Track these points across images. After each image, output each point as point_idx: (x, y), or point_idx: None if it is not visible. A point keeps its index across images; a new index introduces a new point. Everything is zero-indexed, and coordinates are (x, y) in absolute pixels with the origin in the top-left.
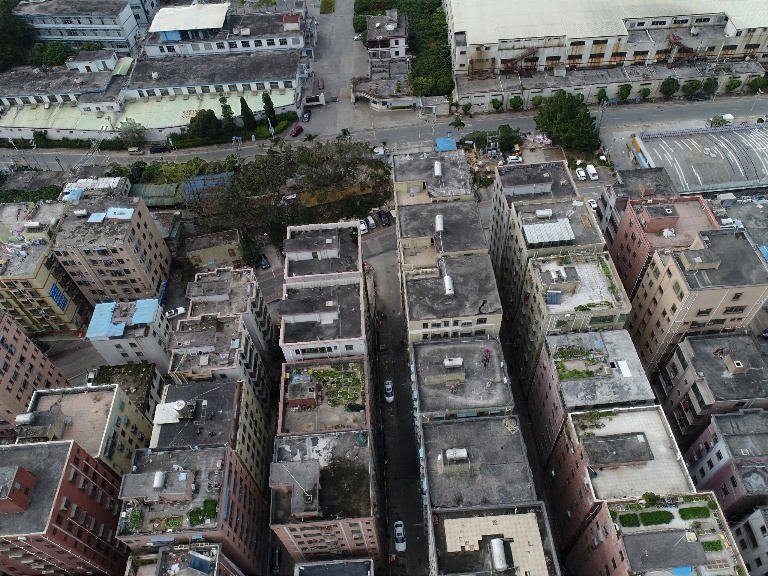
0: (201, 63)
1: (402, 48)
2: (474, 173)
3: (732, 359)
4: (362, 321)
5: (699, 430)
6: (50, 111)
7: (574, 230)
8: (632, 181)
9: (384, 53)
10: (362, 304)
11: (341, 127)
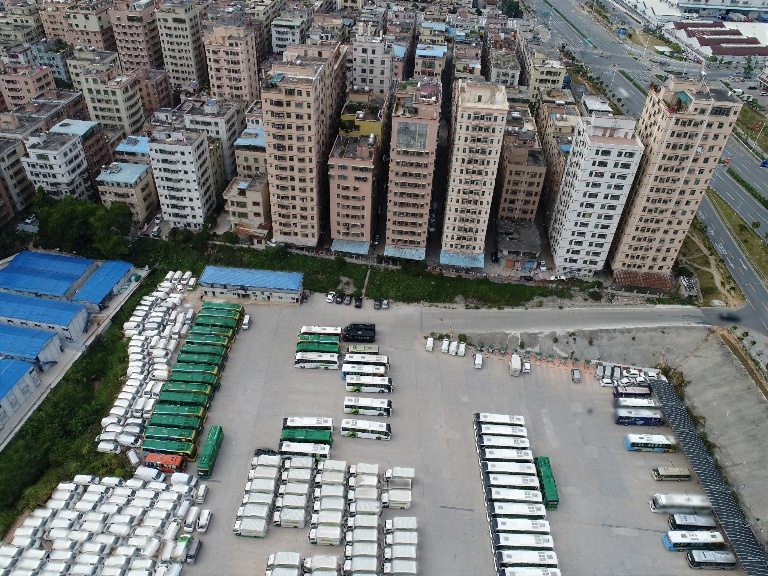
0: None
1: None
2: None
3: (347, 8)
4: None
5: None
6: None
7: None
8: None
9: None
10: None
11: None
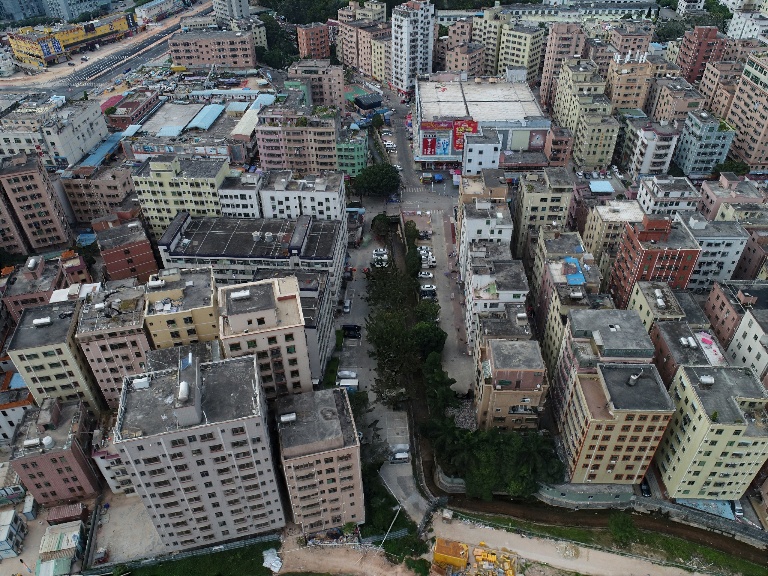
0: (608, 4)
1: (702, 4)
2: None
3: None
4: None
5: None
6: (543, 17)
7: None
8: None
9: (693, 6)
10: None
11: None
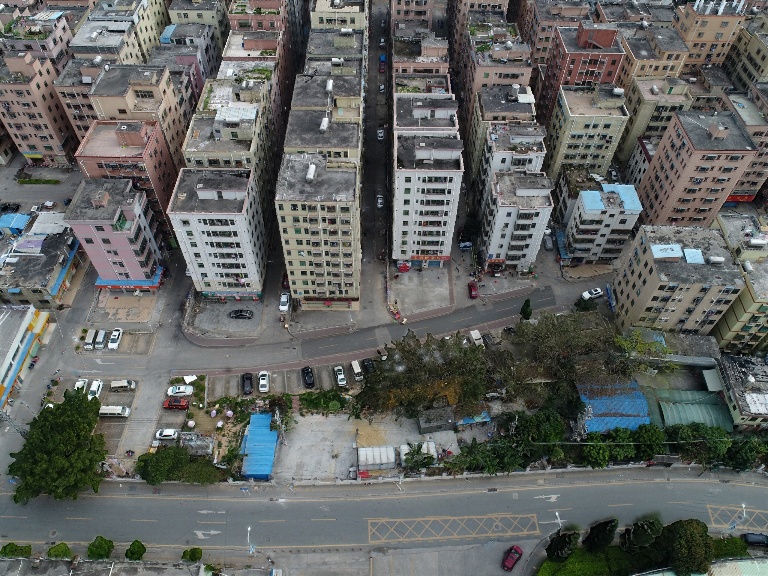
0: None
1: None
2: (235, 411)
3: None
4: (395, 101)
5: (193, 95)
6: None
7: (210, 131)
8: (106, 215)
9: None
10: (395, 111)
11: (430, 566)
